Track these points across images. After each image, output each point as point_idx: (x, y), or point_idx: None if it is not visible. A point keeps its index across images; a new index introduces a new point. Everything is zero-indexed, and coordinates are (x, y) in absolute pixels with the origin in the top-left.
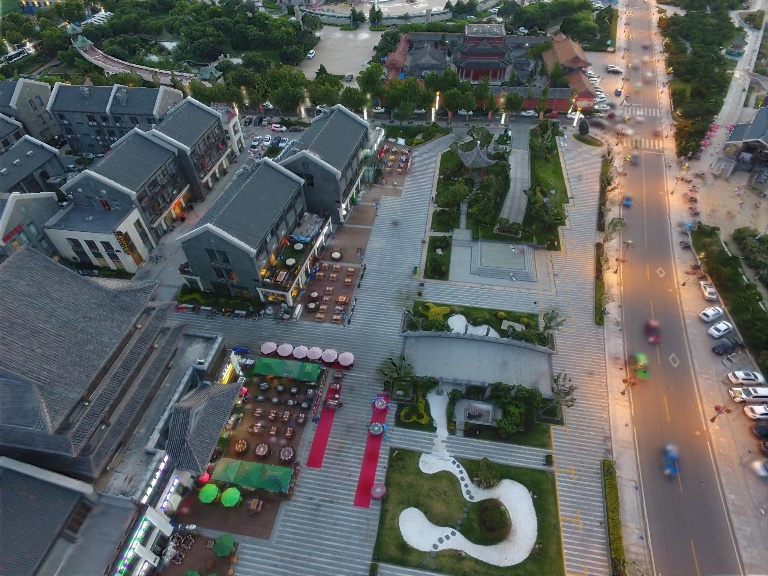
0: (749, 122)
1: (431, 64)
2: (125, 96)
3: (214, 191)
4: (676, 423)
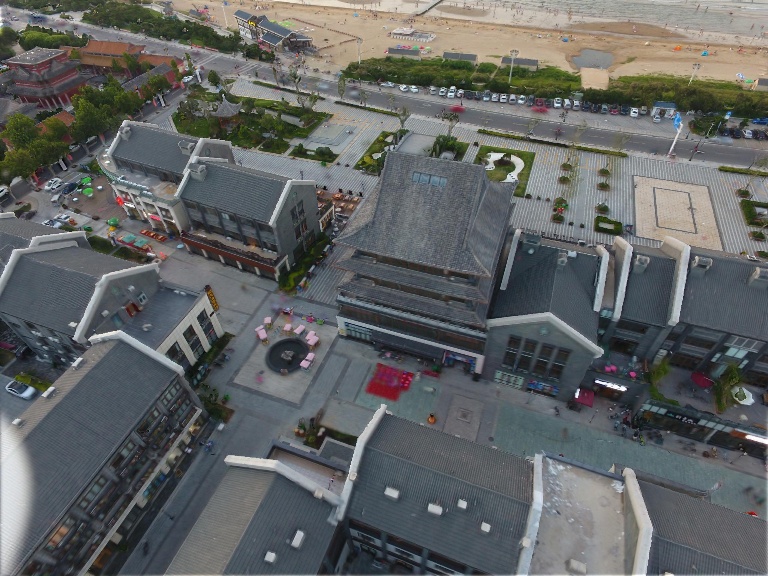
0: None
1: (21, 109)
2: None
3: None
4: (461, 113)
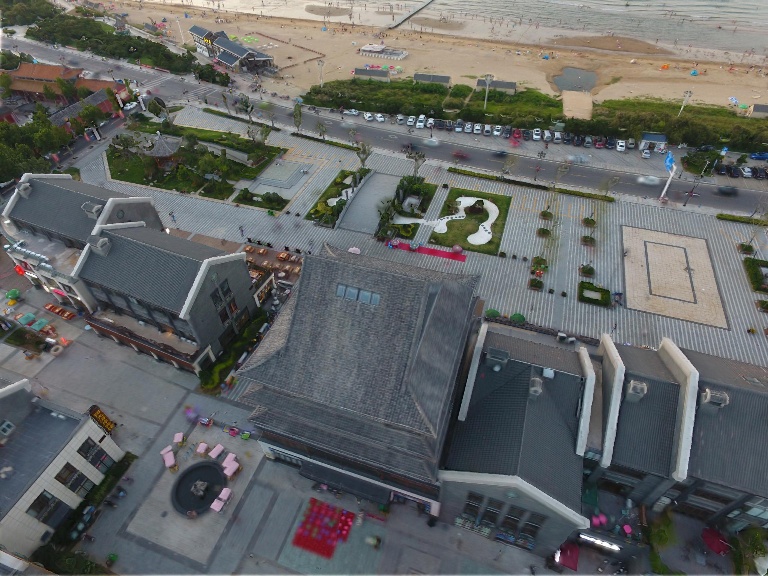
0: (209, 58)
1: None
2: None
3: None
4: (430, 147)
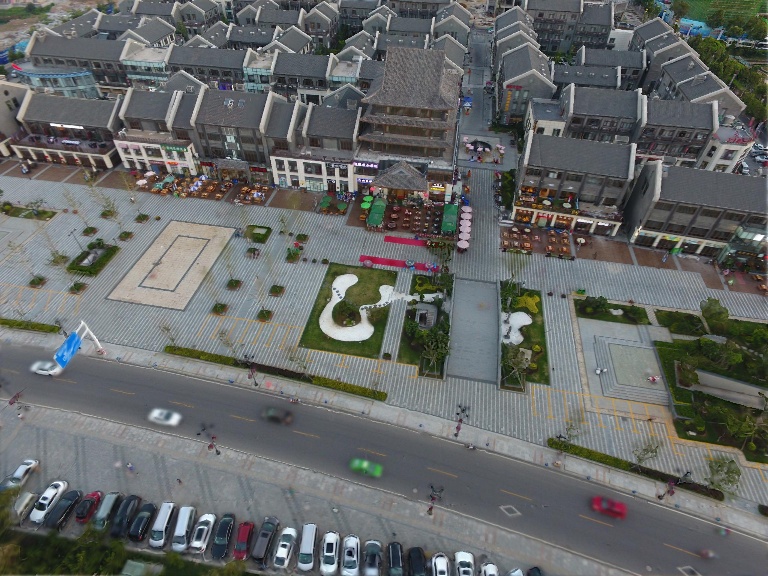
0: None
1: None
2: (701, 81)
3: None
4: (426, 474)
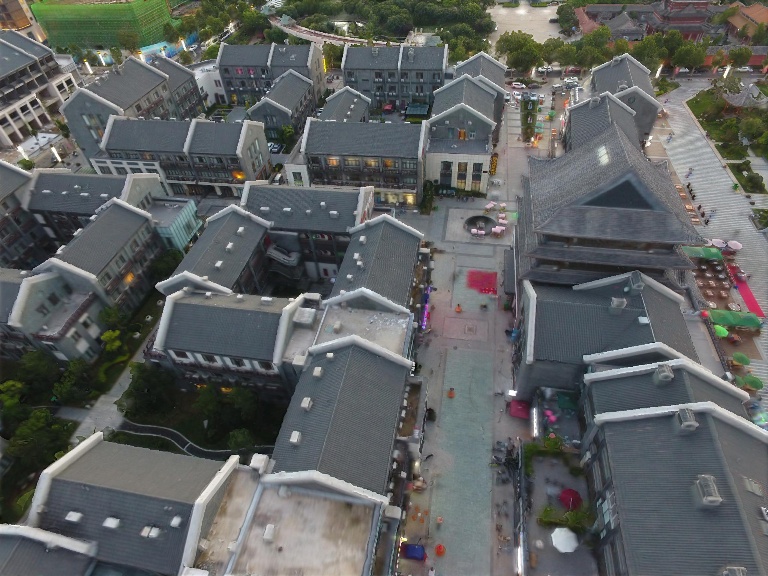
0: None
1: (631, 30)
2: (413, 54)
3: (501, 134)
4: None
